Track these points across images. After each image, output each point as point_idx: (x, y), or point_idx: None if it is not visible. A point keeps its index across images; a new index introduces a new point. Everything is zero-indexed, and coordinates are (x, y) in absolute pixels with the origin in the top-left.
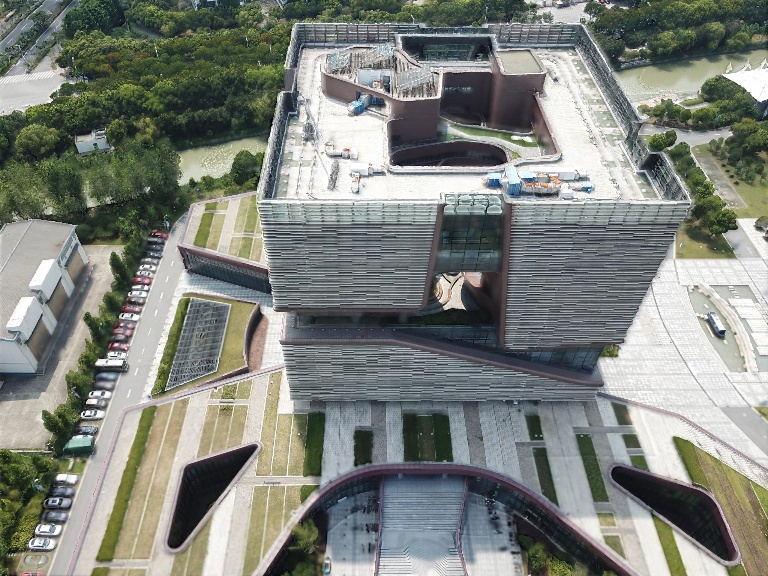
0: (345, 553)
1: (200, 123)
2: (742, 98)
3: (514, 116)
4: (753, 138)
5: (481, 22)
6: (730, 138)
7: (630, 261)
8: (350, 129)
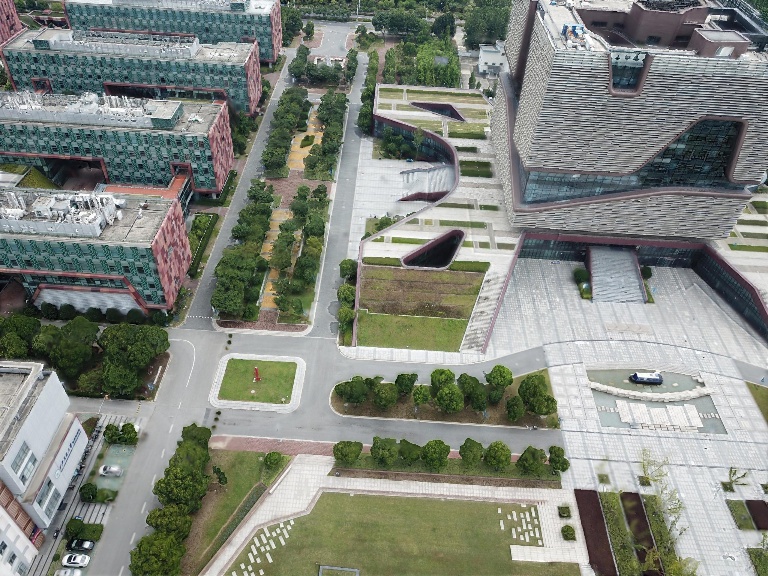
0: (417, 166)
1: None
2: None
3: None
4: None
5: None
6: None
7: None
8: None
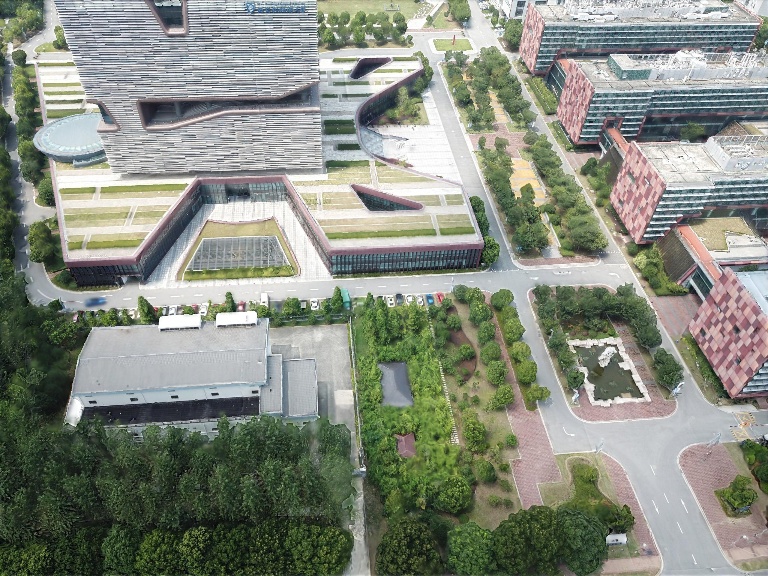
0: None
1: None
2: None
3: None
4: None
5: None
6: None
7: None
8: None
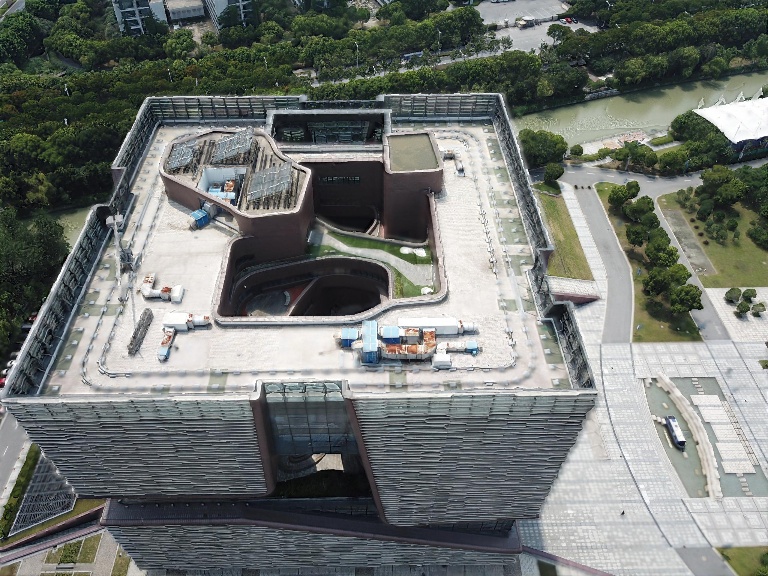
0: None
1: (104, 177)
2: (715, 139)
3: (408, 217)
4: (725, 189)
5: (434, 47)
6: (700, 187)
7: (528, 449)
8: (186, 251)
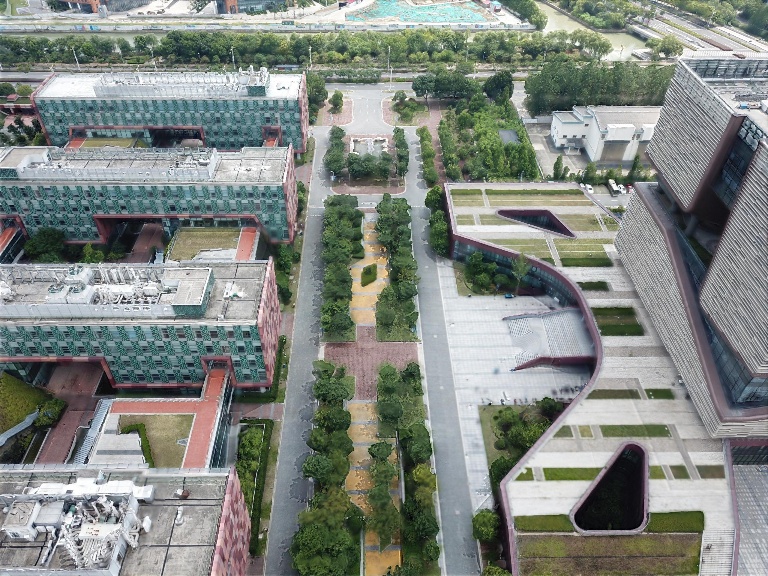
0: (521, 305)
1: None
2: None
3: None
4: None
5: None
6: None
7: None
8: None
